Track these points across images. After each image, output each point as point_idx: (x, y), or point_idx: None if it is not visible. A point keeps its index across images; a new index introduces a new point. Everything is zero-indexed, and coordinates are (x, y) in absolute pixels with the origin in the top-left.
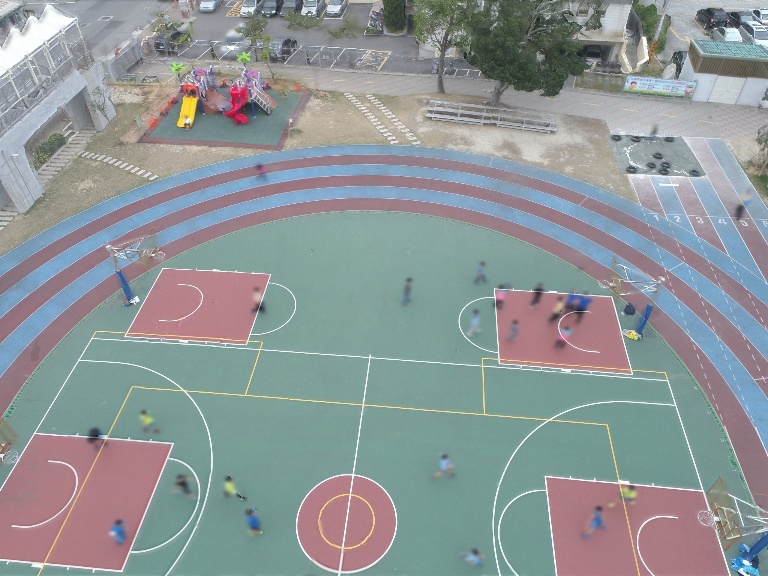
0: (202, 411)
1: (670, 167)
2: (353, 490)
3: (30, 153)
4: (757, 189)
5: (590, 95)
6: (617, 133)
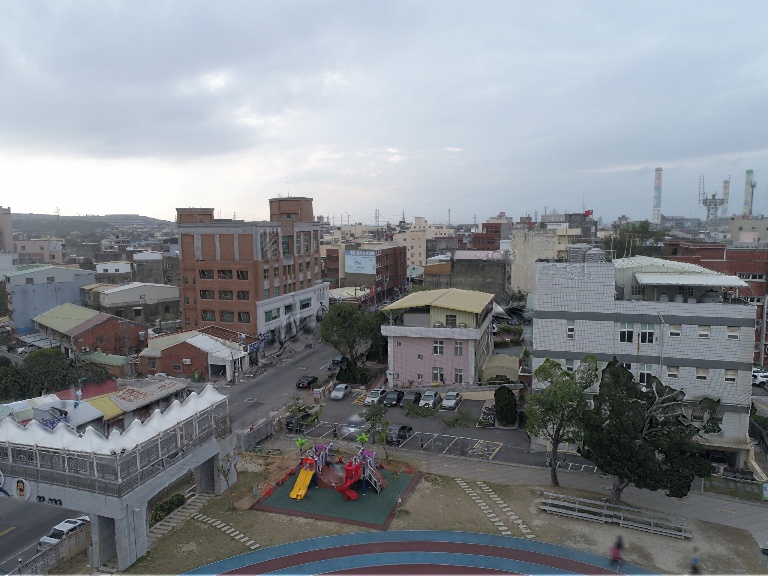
0: None
1: None
2: None
3: (150, 510)
4: None
5: (724, 501)
6: (767, 547)
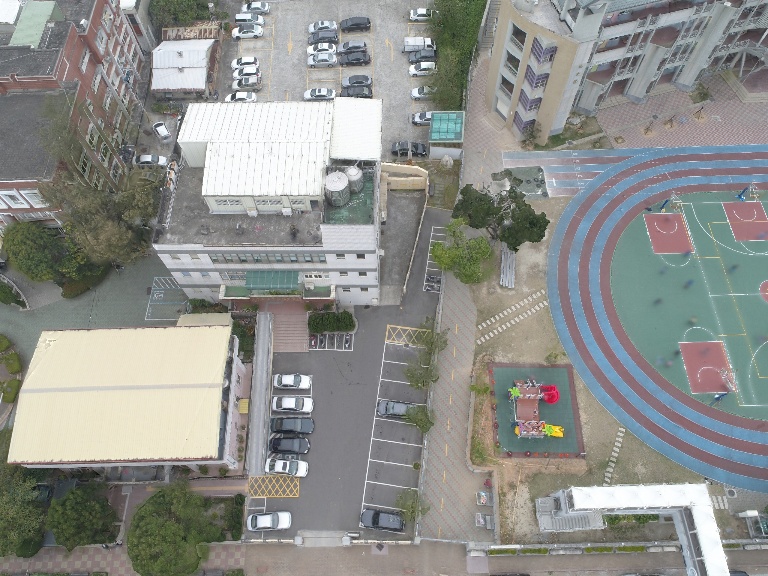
0: (759, 348)
1: (537, 179)
2: (766, 293)
3: None
4: (546, 150)
5: None
6: None
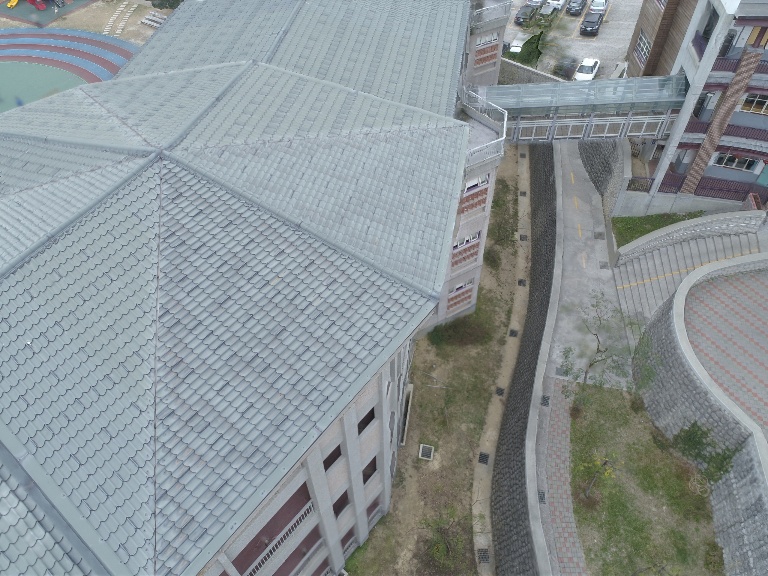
0: None
1: None
2: None
3: None
4: None
5: None
6: None
